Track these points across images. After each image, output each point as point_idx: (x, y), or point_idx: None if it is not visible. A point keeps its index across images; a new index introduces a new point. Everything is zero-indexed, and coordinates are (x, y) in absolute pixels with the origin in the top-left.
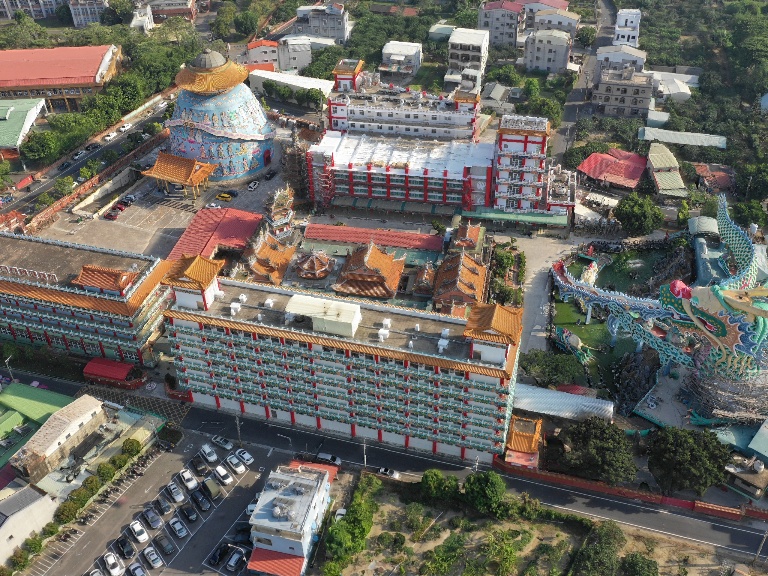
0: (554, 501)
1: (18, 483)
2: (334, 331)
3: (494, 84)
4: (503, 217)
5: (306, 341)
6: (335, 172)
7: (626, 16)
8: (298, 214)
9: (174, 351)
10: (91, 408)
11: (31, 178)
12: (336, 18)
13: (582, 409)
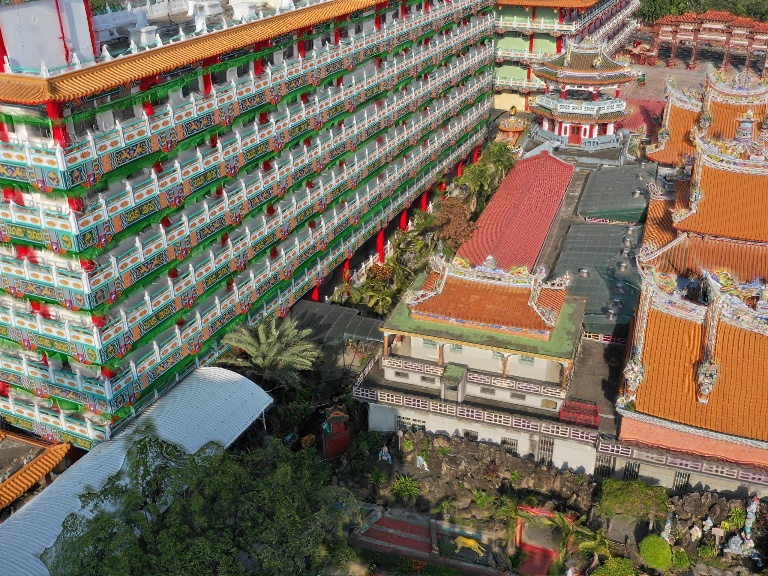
0: None
1: None
2: None
3: None
4: None
5: None
6: None
7: None
8: None
9: None
10: None
11: None
12: None
13: None
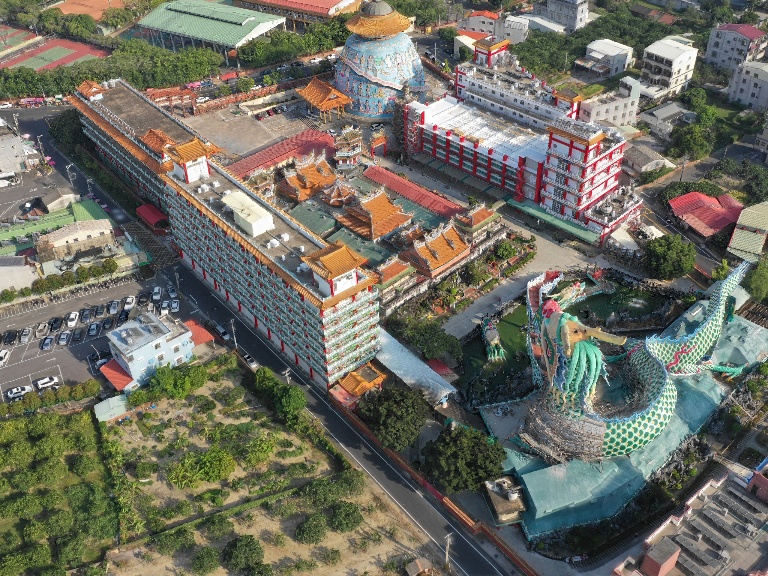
0: (343, 440)
1: (36, 258)
2: (244, 227)
3: (670, 103)
4: (541, 216)
5: (222, 227)
6: (424, 130)
7: None
8: (388, 159)
9: (168, 209)
10: (101, 228)
11: (236, 74)
12: (571, 6)
13: (422, 382)
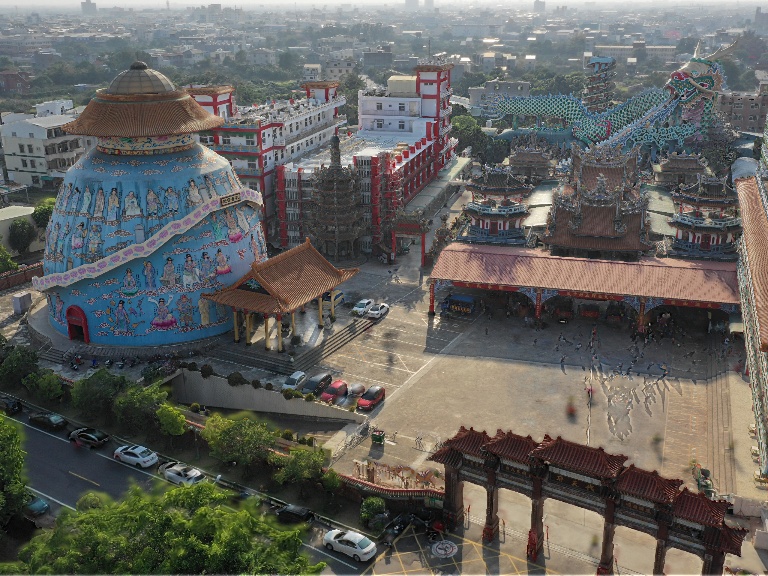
0: None
1: None
2: None
3: None
4: (457, 170)
5: None
6: None
7: (58, 105)
8: (400, 260)
9: None
10: None
11: None
12: None
13: None
